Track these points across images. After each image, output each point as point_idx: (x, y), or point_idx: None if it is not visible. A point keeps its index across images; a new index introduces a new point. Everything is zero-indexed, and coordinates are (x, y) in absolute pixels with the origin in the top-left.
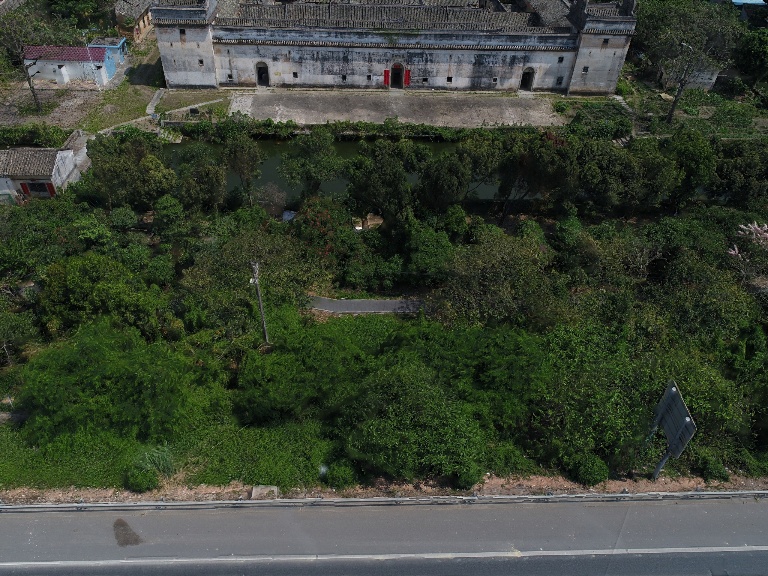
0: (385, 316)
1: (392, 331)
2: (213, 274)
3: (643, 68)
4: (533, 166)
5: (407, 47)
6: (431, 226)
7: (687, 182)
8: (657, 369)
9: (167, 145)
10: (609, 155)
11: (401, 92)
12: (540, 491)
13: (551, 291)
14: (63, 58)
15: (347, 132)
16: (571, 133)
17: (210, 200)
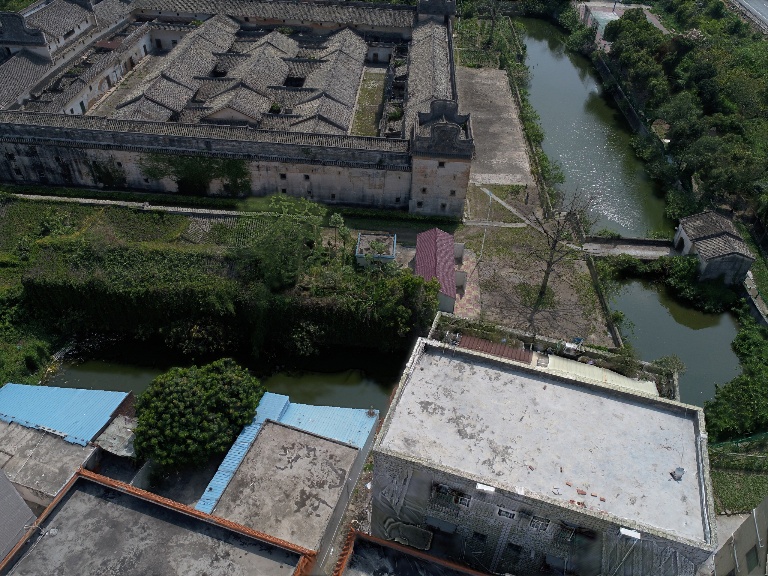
0: None
1: None
2: None
3: None
4: None
5: None
6: None
7: None
8: None
9: None
10: None
11: None
12: None
13: None
14: (452, 264)
15: None
16: None
17: None
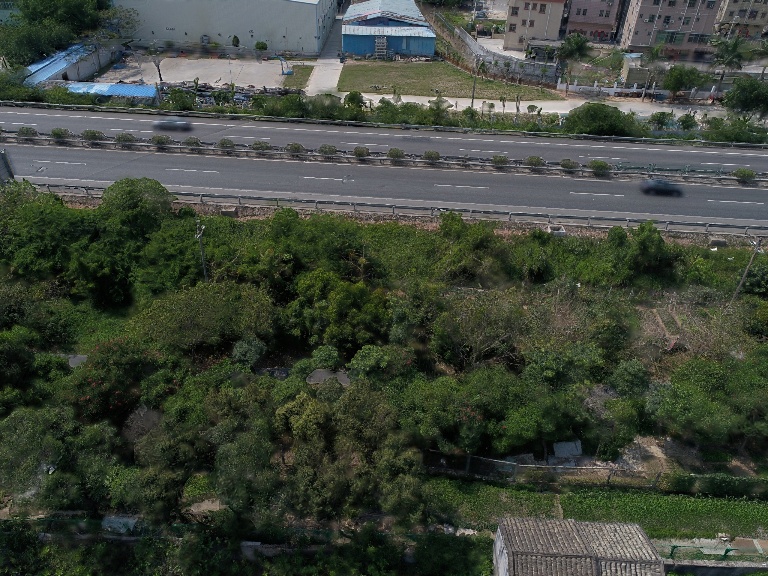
0: None
1: (107, 267)
2: None
3: None
4: None
5: None
6: None
7: None
8: None
9: None
10: None
11: None
12: (87, 201)
13: None
14: None
15: None
16: None
17: None
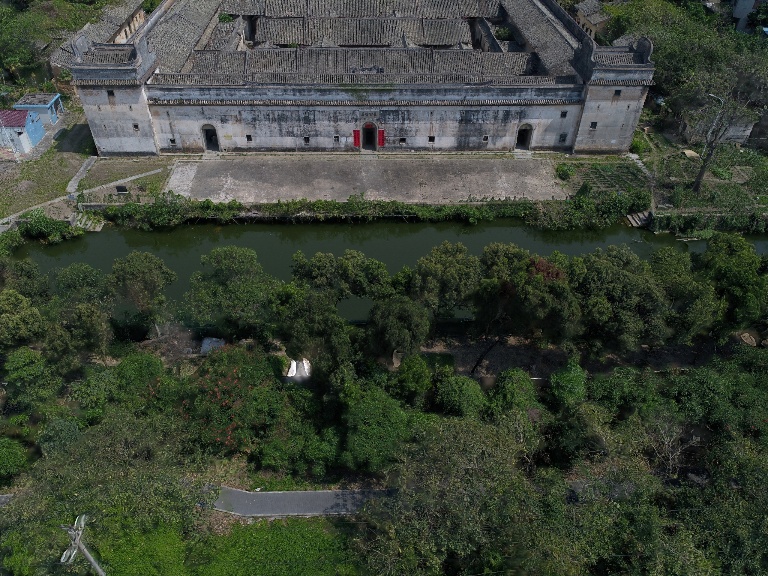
0: (311, 522)
1: None
2: (51, 493)
3: (662, 116)
4: (517, 305)
5: (379, 104)
6: (379, 385)
7: (730, 316)
8: None
9: (84, 234)
10: (622, 284)
11: (374, 155)
12: None
13: (540, 508)
14: None
15: (303, 213)
16: (576, 208)
17: (88, 346)
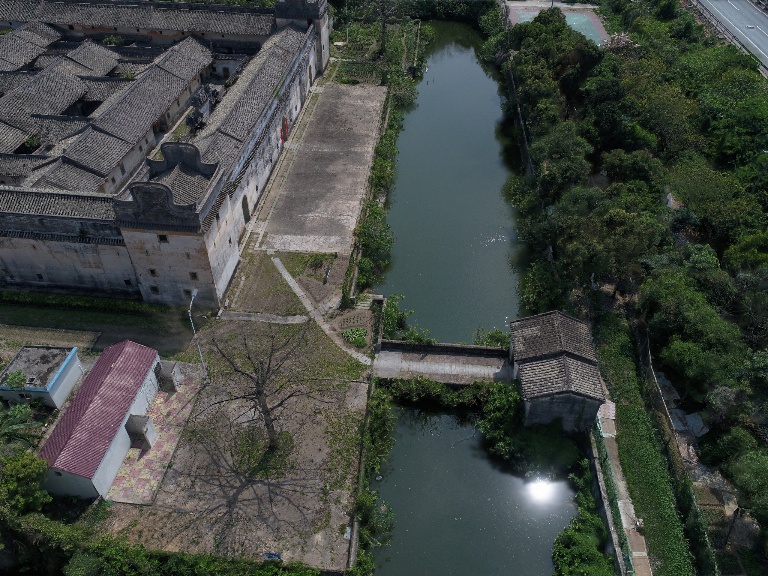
0: None
1: (733, 151)
2: None
3: None
4: None
5: None
6: None
7: None
8: None
9: None
10: (571, 45)
11: (292, 143)
12: None
13: None
14: (124, 407)
15: None
16: None
17: None
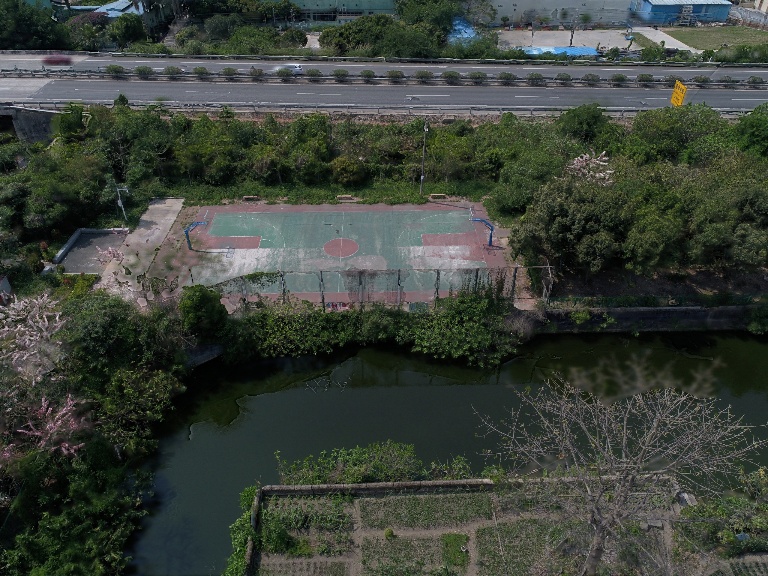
0: None
1: None
2: None
3: None
4: None
5: None
6: None
7: None
8: (684, 109)
9: None
10: None
11: None
12: None
13: None
14: None
15: None
16: None
17: None
